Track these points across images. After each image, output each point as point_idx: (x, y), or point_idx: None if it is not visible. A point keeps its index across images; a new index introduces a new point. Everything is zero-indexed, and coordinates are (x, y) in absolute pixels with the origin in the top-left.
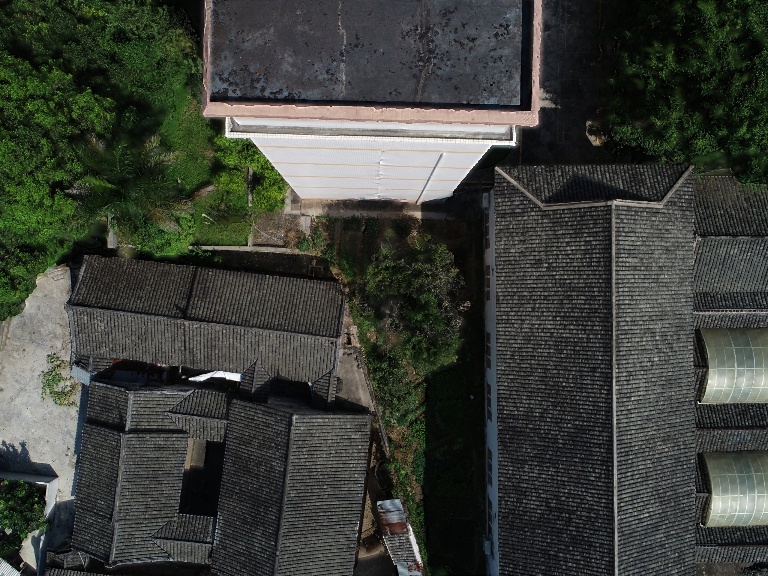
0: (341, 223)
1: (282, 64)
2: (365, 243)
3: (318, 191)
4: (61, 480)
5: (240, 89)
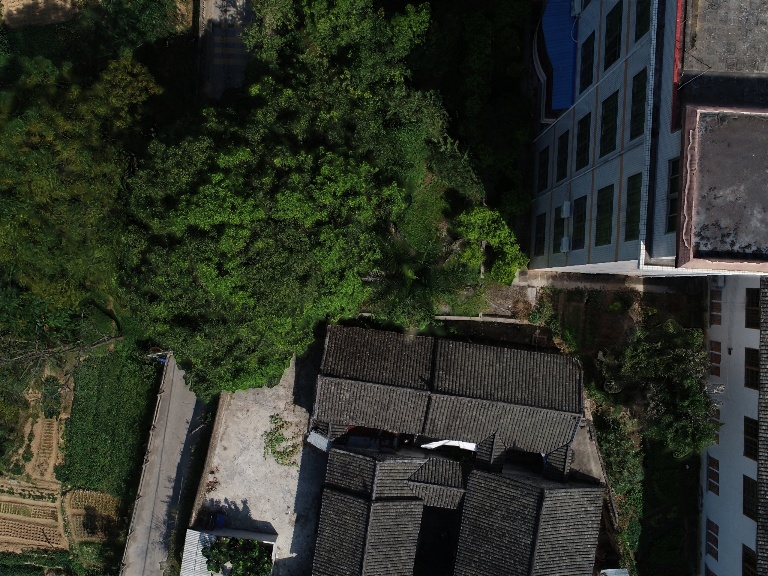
0: (564, 294)
1: (751, 220)
2: (588, 314)
3: None
4: (280, 538)
5: (711, 243)
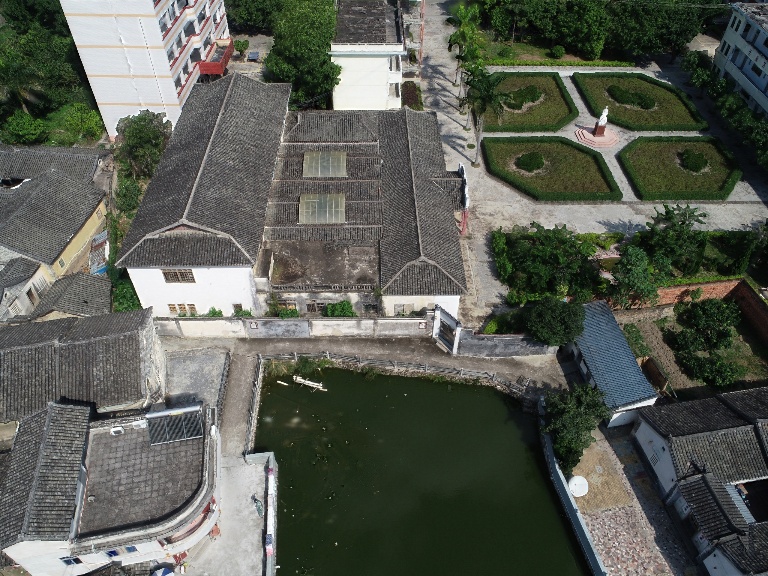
0: None
1: None
2: None
3: (114, 116)
4: None
5: None
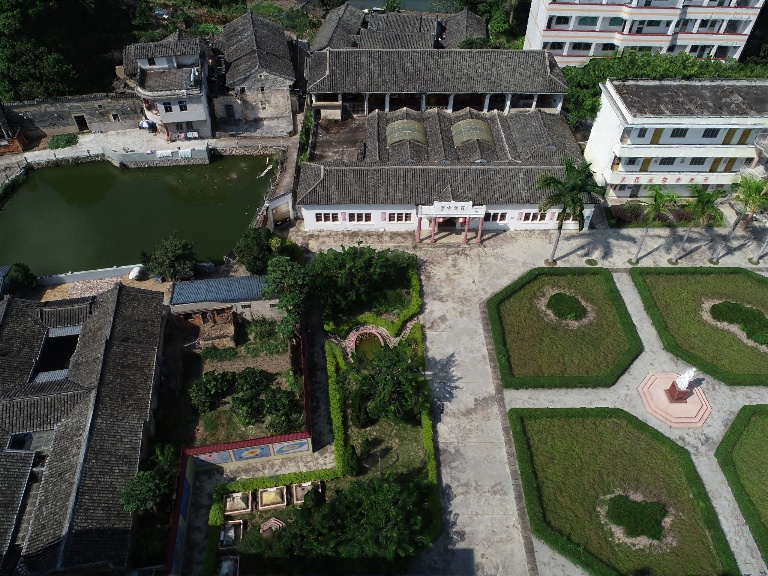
0: None
1: None
2: None
3: None
4: None
5: None
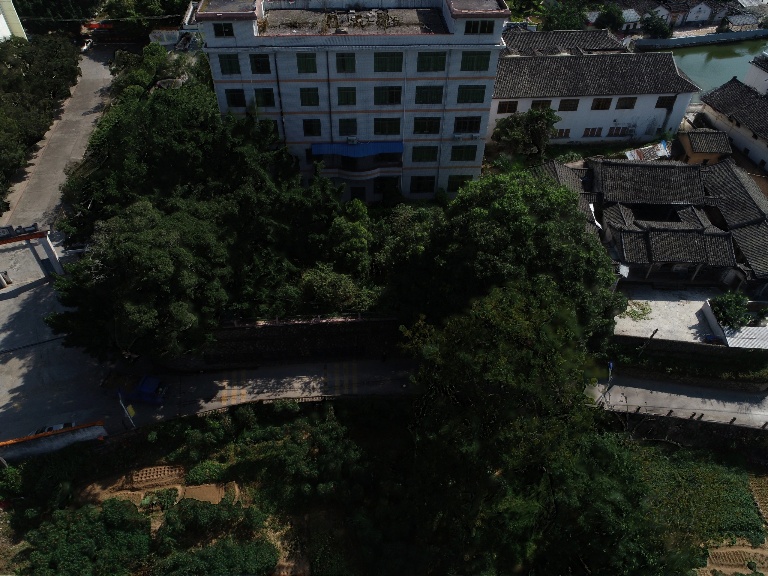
0: None
1: None
2: None
3: None
4: None
5: None
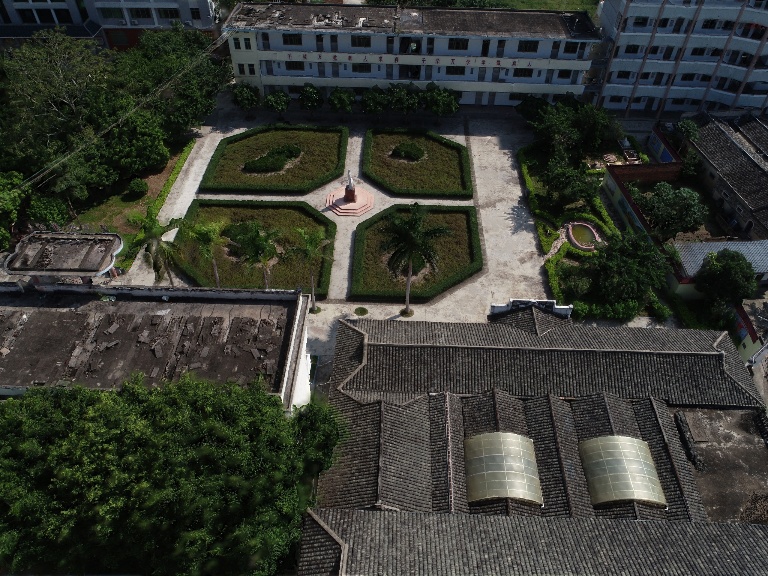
0: None
1: None
2: None
3: None
4: None
5: None
